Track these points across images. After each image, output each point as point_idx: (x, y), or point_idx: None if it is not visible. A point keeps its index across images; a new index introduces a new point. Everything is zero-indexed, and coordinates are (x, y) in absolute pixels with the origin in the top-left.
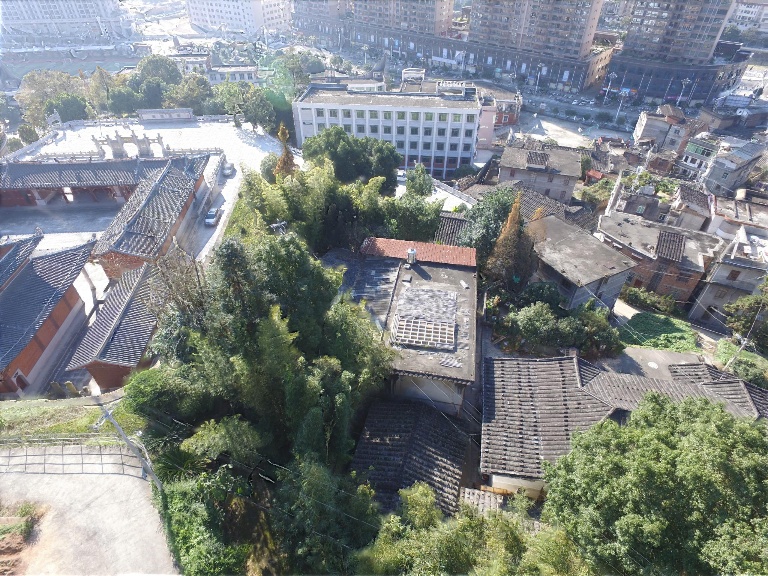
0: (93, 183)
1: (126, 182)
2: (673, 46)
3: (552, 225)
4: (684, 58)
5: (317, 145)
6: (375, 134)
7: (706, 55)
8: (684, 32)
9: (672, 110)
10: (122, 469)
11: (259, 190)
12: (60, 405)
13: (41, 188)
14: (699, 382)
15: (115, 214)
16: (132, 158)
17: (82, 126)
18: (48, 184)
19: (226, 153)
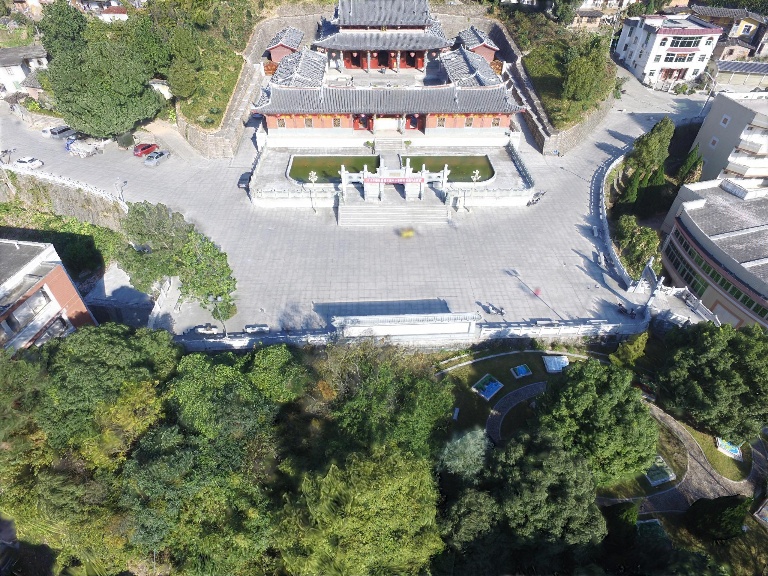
0: None
1: None
2: None
3: (3, 62)
4: None
5: None
6: None
7: None
8: None
9: None
10: None
11: None
12: (292, 16)
13: None
14: None
15: None
16: (328, 86)
17: (611, 322)
18: None
19: (252, 218)
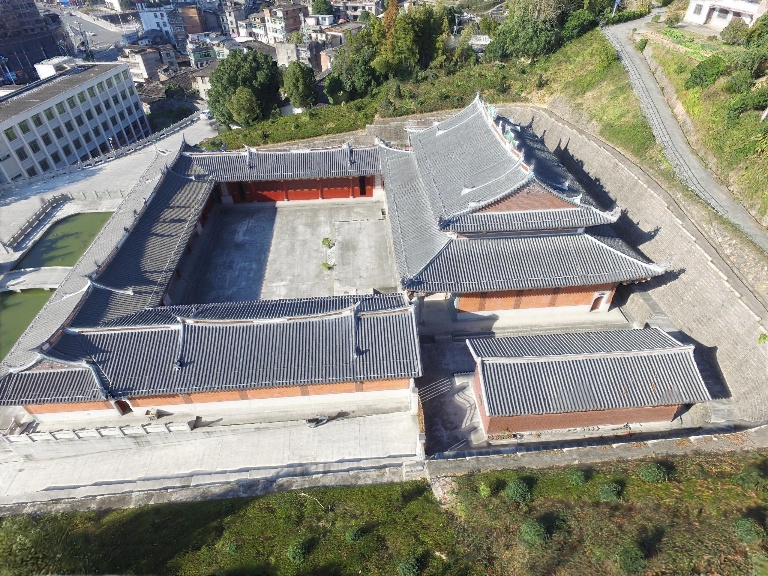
0: (197, 210)
1: (208, 188)
2: (7, 21)
3: None
4: (25, 30)
5: (249, 66)
6: (72, 132)
7: (40, 21)
8: (5, 6)
9: (139, 46)
10: (608, 29)
11: (432, 9)
12: None
13: (181, 256)
14: (479, 32)
15: (231, 231)
16: (164, 172)
17: None
18: (178, 247)
19: None
